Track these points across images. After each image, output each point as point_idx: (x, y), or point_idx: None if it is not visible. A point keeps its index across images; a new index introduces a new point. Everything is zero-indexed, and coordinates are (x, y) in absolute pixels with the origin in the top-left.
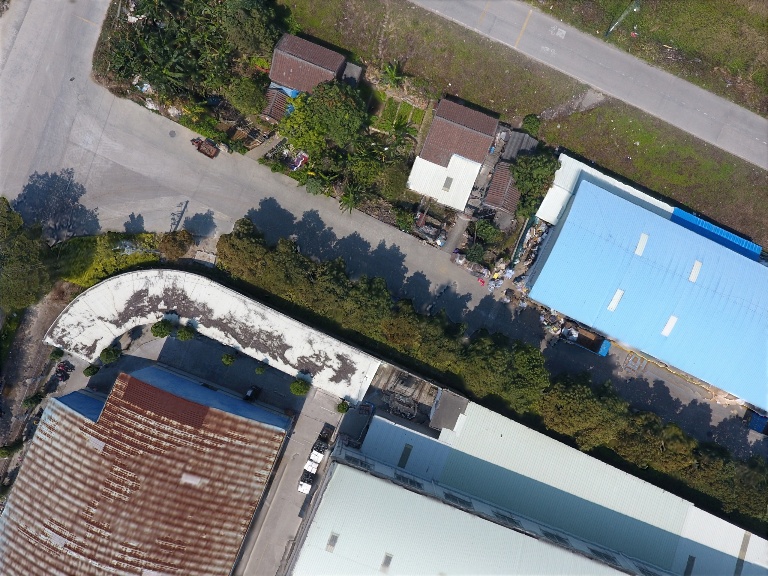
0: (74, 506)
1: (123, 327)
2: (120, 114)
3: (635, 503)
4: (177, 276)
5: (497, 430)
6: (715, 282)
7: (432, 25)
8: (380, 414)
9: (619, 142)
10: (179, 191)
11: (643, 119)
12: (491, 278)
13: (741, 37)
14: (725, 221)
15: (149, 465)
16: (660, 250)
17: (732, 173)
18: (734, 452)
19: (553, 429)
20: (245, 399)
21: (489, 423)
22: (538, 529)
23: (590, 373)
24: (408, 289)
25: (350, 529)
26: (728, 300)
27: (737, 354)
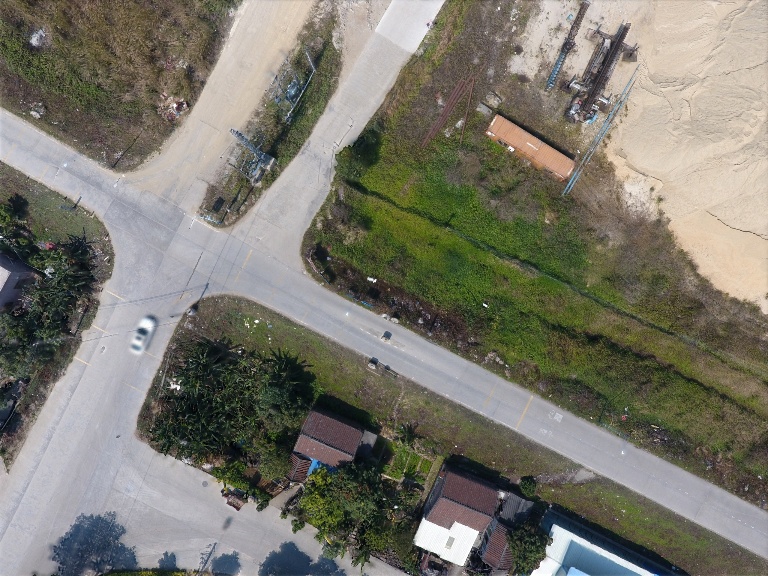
0: None
1: None
2: (159, 466)
3: None
4: None
5: None
6: None
7: (442, 407)
8: None
9: (607, 507)
10: (208, 534)
11: (629, 496)
12: None
13: (722, 422)
14: None
15: None
16: None
17: (708, 546)
18: None
19: None
20: None
21: None
22: None
23: None
24: None
25: None
26: None
27: None
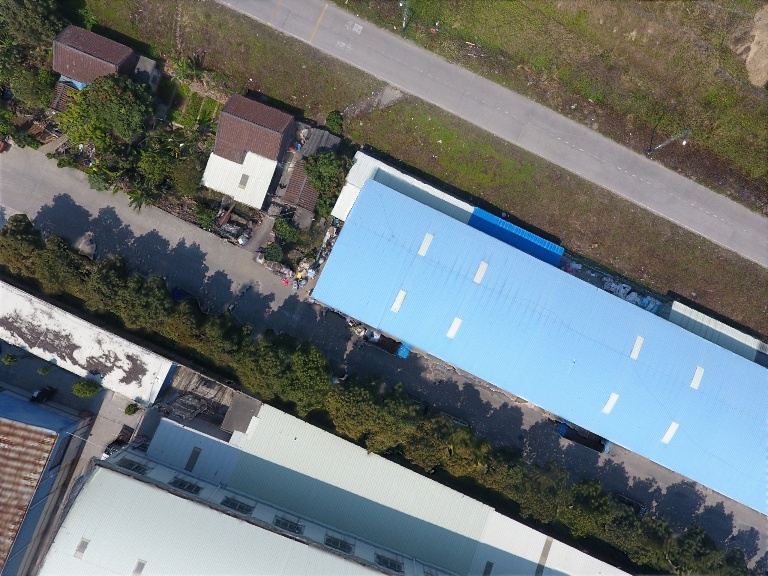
0: None
1: None
2: None
3: (433, 508)
4: None
5: (291, 433)
6: (501, 283)
7: (224, 18)
8: (172, 416)
9: (423, 140)
10: None
11: (442, 117)
12: (295, 278)
13: (545, 35)
14: (534, 222)
15: None
16: (444, 250)
17: (534, 173)
18: (546, 456)
19: (344, 432)
20: (31, 400)
21: (283, 426)
22: (323, 534)
23: (381, 375)
24: (209, 288)
25: (102, 535)
26: (513, 302)
27: (523, 357)
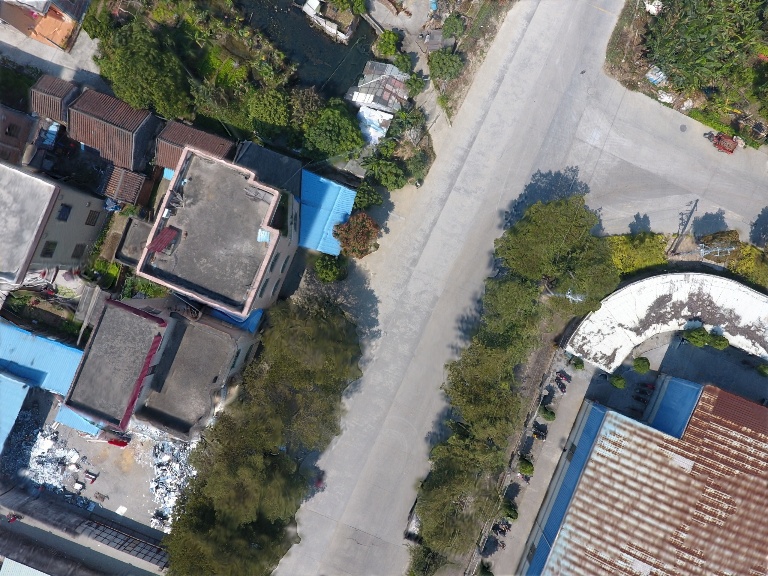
0: (659, 530)
1: (643, 335)
2: (630, 108)
3: None
4: (704, 280)
5: None
6: None
7: None
8: None
9: None
10: (689, 189)
11: None
12: None
13: None
14: None
15: (746, 486)
16: None
17: None
18: None
19: None
20: None
21: None
22: None
23: None
24: None
25: None
26: None
27: None
